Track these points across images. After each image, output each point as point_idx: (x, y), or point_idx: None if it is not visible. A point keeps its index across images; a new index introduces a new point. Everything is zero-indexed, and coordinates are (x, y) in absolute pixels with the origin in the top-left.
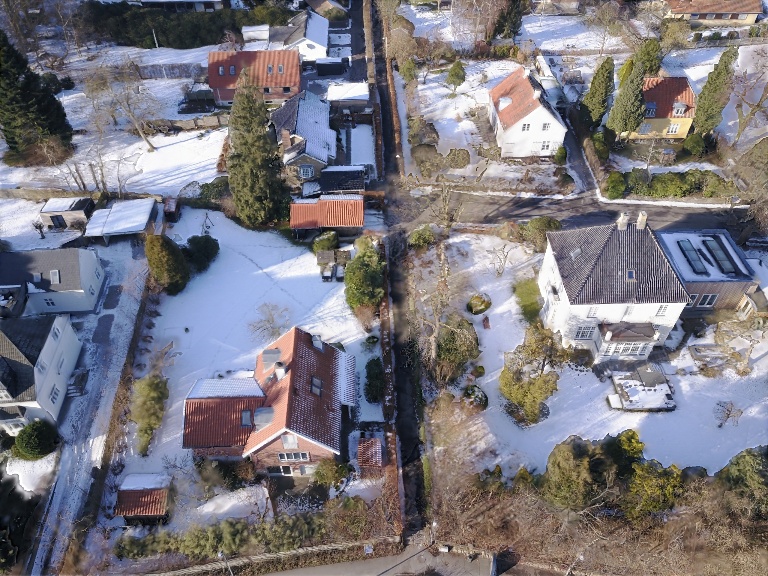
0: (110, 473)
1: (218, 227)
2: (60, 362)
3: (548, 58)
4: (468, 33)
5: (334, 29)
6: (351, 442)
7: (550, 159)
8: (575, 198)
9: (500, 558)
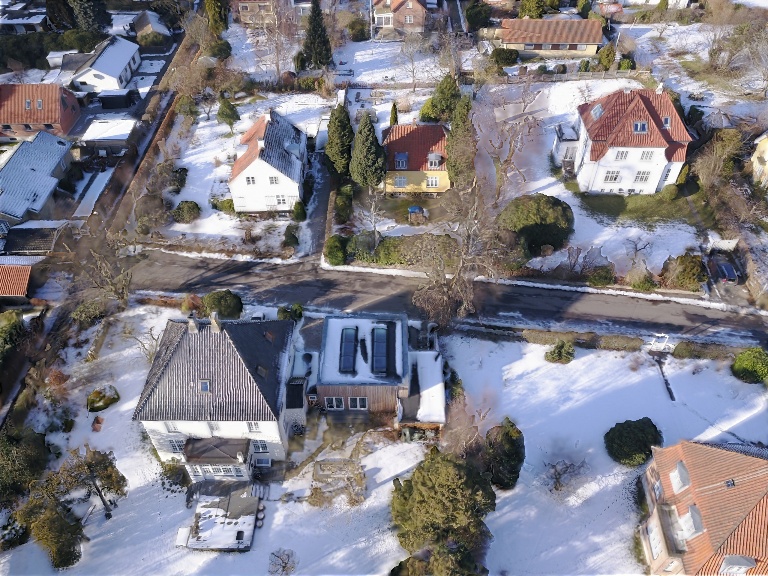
0: None
1: None
2: None
3: (355, 92)
4: (268, 64)
5: (152, 55)
6: None
7: (290, 214)
8: (294, 263)
9: None
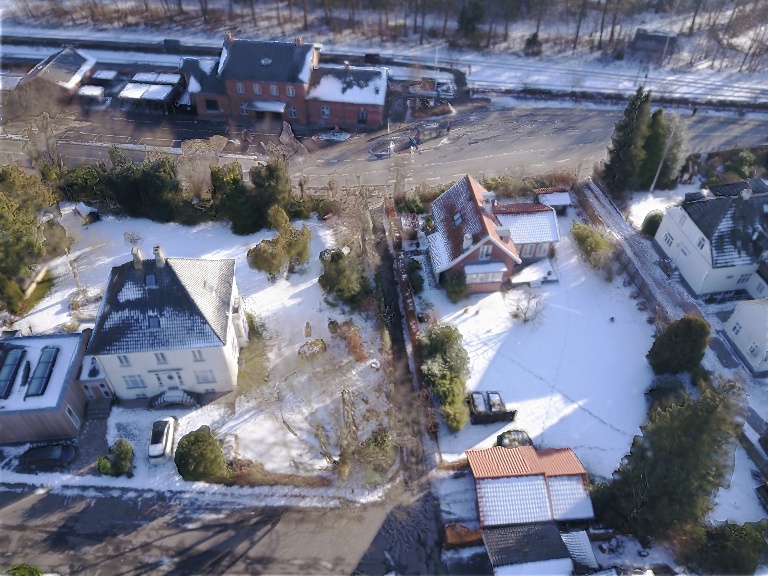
0: (589, 220)
1: None
2: (685, 250)
3: None
4: None
5: None
6: (426, 243)
7: None
8: None
9: None
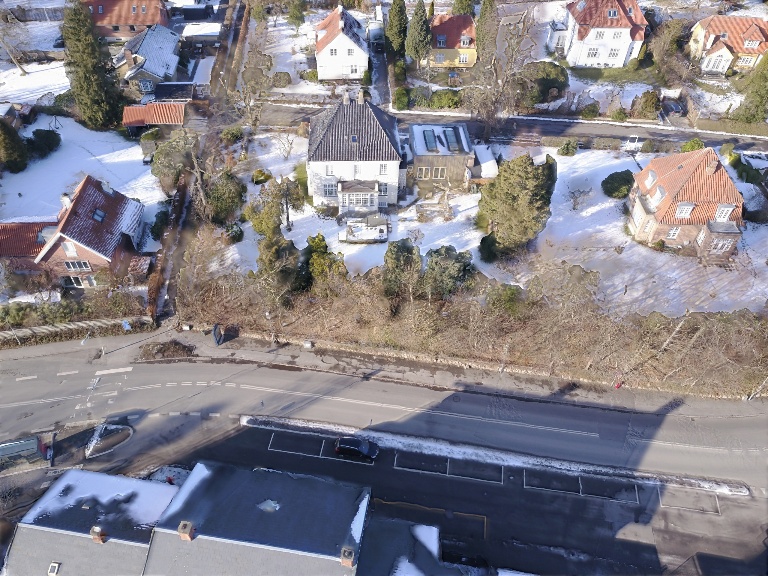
0: None
1: (66, 128)
2: None
3: (388, 9)
4: None
5: None
6: None
7: (359, 82)
8: None
9: (227, 333)
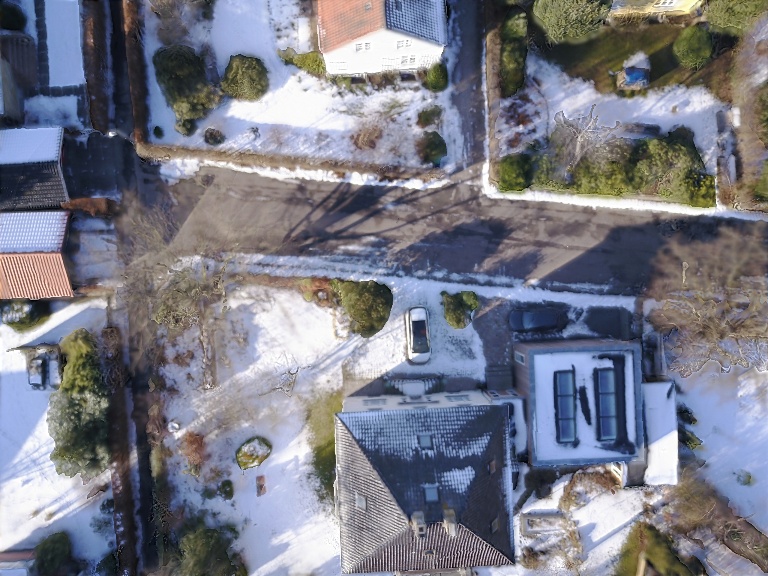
0: None
1: None
2: None
3: None
4: None
5: None
6: None
7: (419, 72)
8: (443, 186)
9: None
